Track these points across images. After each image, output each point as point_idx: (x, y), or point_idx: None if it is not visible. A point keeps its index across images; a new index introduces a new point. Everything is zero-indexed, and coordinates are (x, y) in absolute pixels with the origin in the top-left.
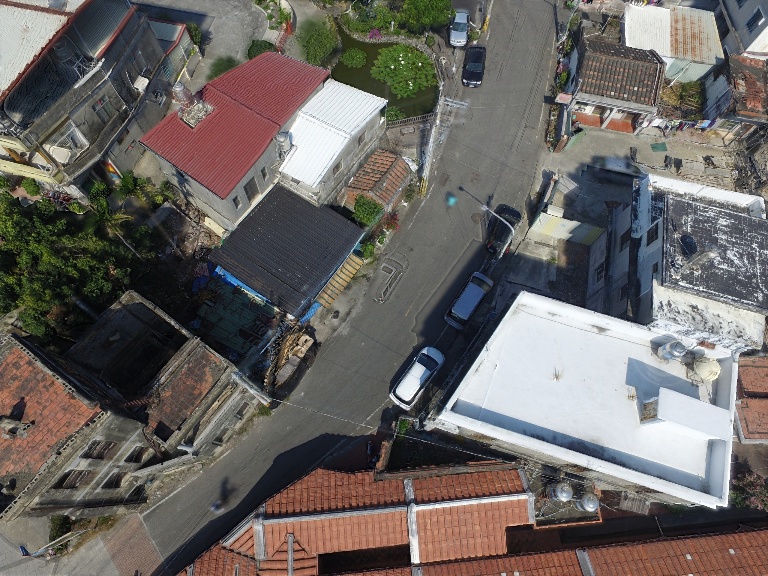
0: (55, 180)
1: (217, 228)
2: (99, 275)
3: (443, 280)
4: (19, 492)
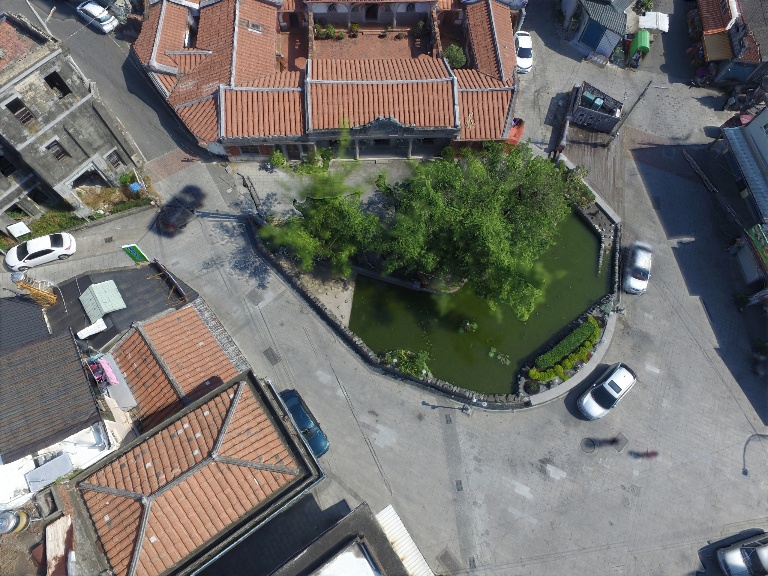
0: None
1: None
2: None
3: (30, 2)
4: None
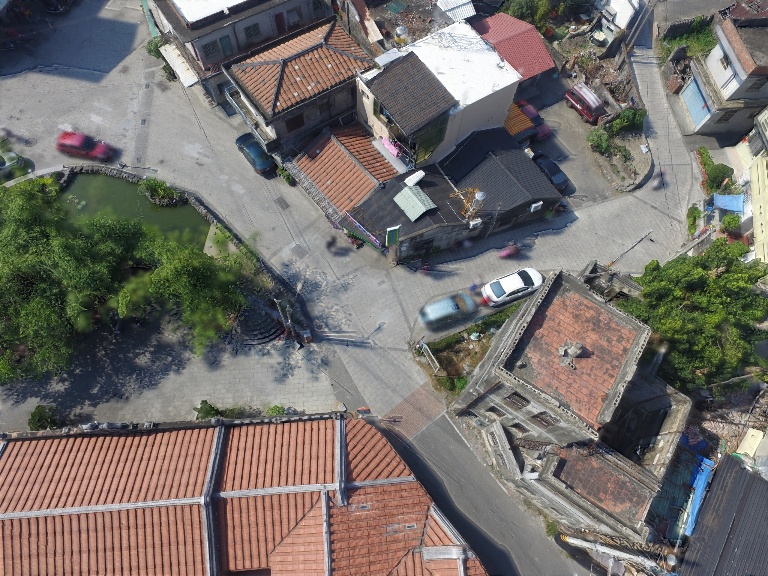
0: (765, 279)
1: (751, 446)
2: (695, 363)
3: None
4: (517, 373)
